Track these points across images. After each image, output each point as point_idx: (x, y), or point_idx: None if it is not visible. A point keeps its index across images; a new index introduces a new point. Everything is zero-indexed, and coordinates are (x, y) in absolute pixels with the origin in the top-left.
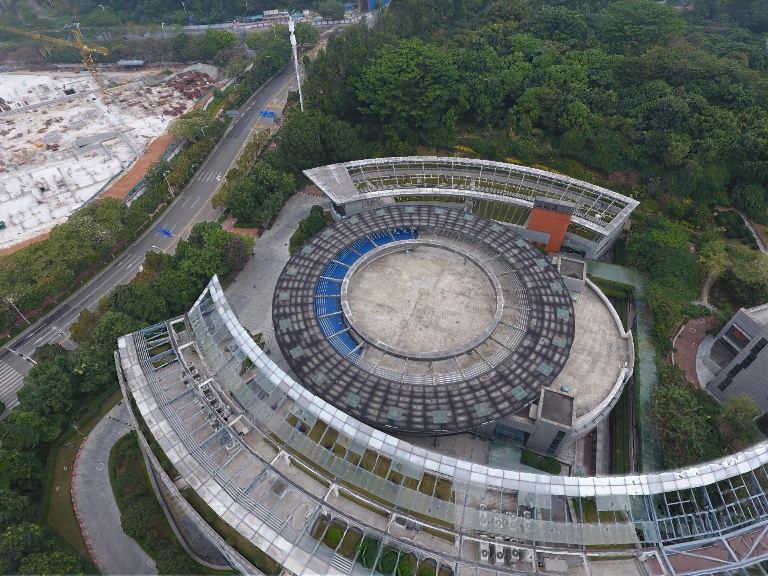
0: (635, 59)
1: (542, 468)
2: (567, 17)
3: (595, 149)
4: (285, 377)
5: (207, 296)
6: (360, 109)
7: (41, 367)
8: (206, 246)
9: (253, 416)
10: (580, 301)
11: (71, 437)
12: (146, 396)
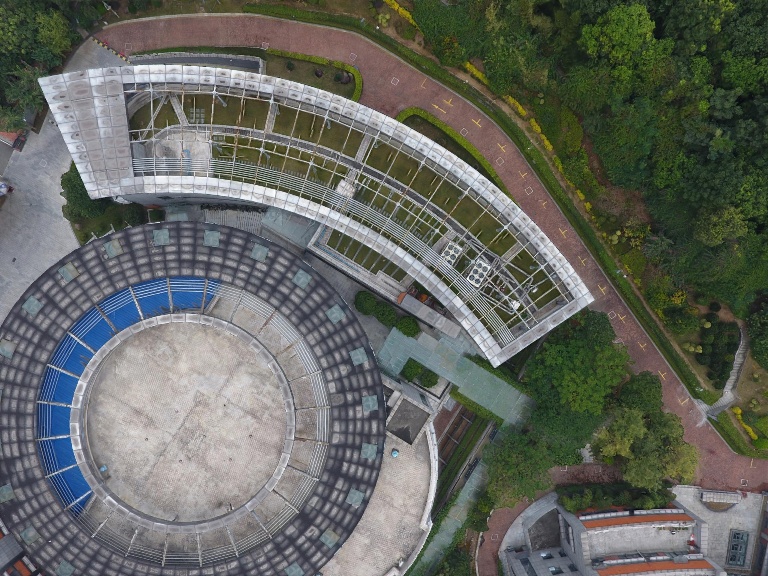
0: None
1: None
2: None
3: (610, 130)
4: None
5: None
6: None
7: None
8: None
9: None
10: (402, 456)
11: None
12: None
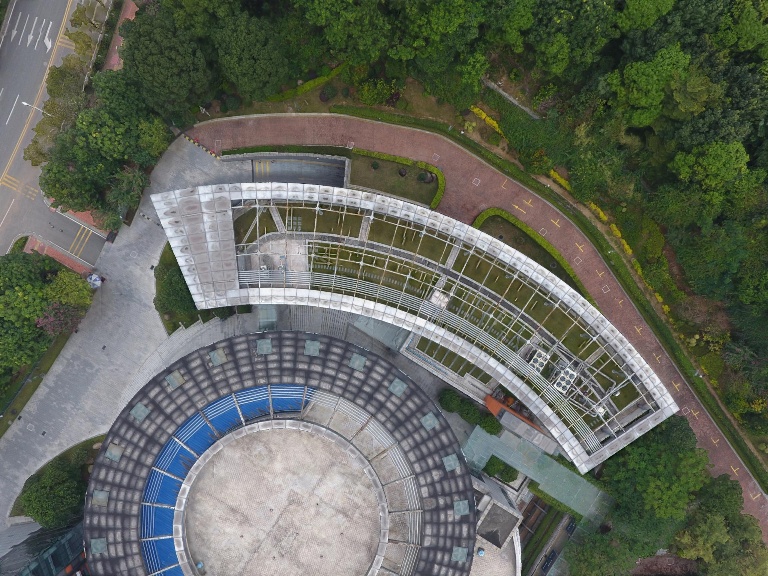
0: None
1: None
2: None
3: (697, 248)
4: None
5: None
6: None
7: None
8: (7, 319)
9: None
10: (488, 555)
11: None
12: None
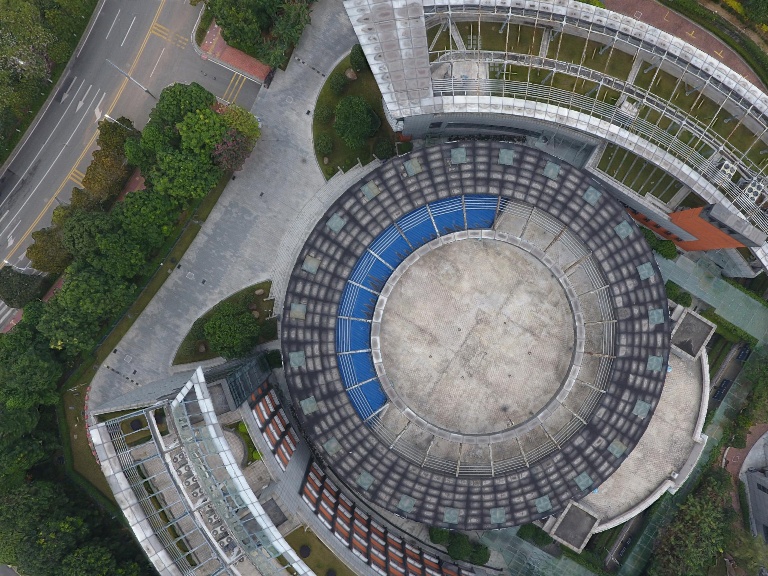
0: None
1: (534, 540)
2: None
3: None
4: (289, 551)
5: (198, 204)
6: None
7: (10, 343)
8: (186, 145)
9: (255, 564)
10: (674, 372)
11: (73, 385)
12: (138, 517)
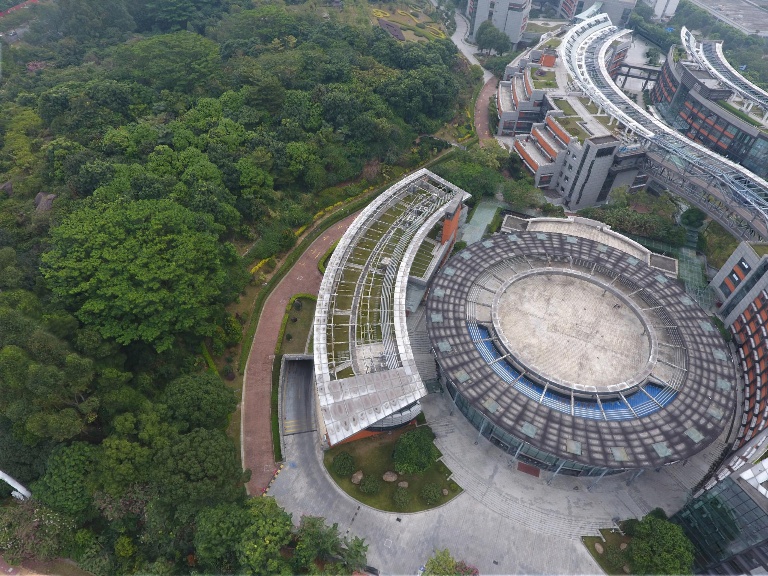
0: (266, 85)
1: None
2: (123, 87)
3: (338, 167)
4: None
5: None
6: (164, 348)
7: None
8: None
9: None
10: None
11: None
12: None
